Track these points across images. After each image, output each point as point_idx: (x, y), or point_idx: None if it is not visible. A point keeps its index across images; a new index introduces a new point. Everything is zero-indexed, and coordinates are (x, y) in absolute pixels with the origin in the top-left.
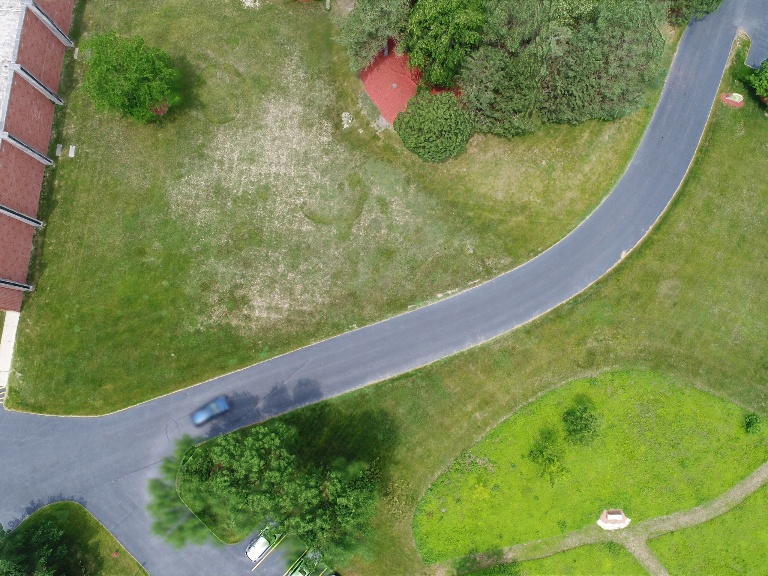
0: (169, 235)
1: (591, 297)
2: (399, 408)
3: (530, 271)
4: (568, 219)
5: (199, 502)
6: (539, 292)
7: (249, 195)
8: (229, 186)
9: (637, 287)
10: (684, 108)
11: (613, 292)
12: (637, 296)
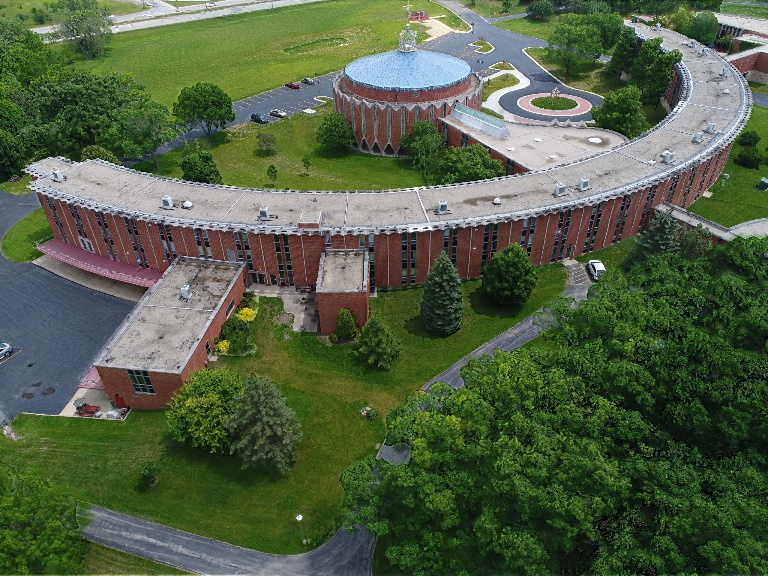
0: None
1: None
2: (738, 1)
3: None
4: None
5: None
6: None
7: None
8: None
9: None
10: None
11: None
12: None
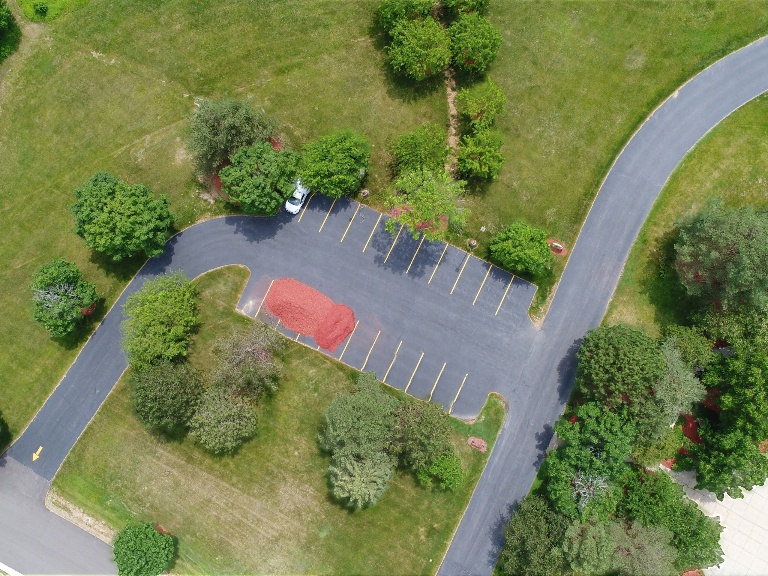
0: None
1: (710, 55)
2: None
3: (767, 81)
4: (731, 128)
5: None
6: (758, 61)
7: None
8: None
9: (666, 63)
10: (606, 240)
11: (689, 59)
12: (666, 54)
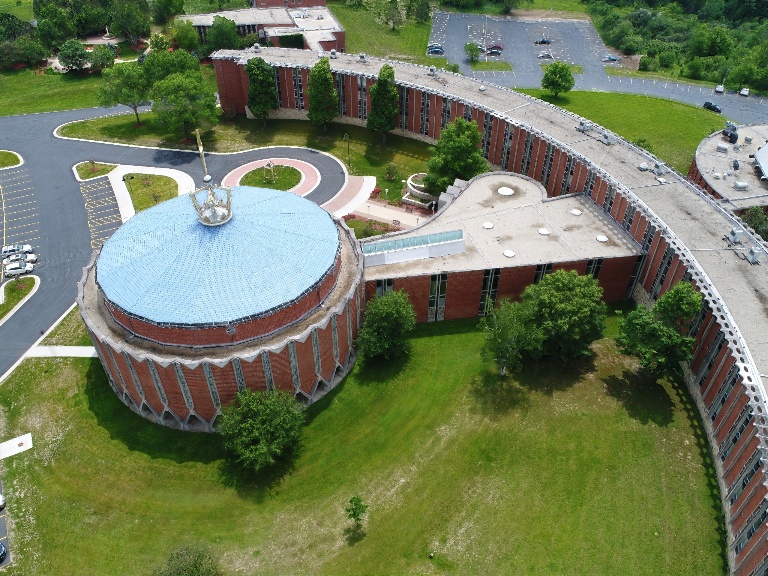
0: (208, 2)
1: None
2: None
3: None
4: None
5: None
6: None
7: (184, 8)
8: (192, 8)
9: None
10: None
11: None
12: None
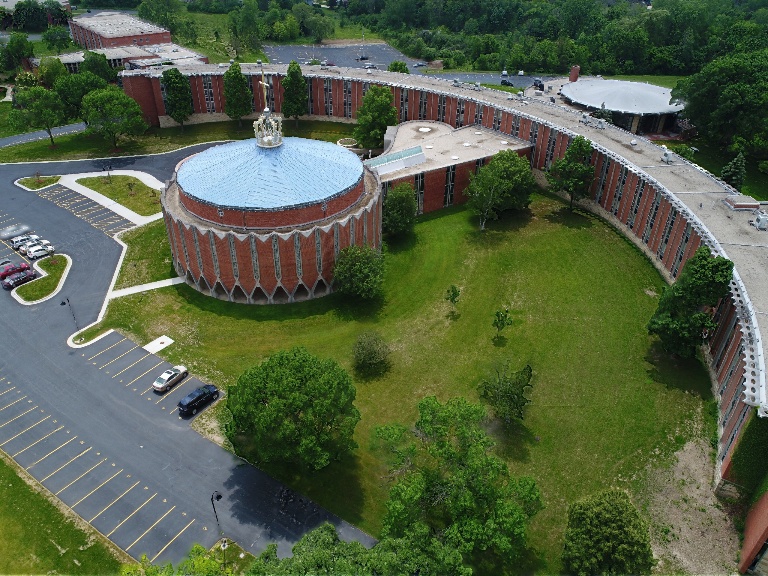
0: None
1: None
2: None
3: None
4: None
5: (0, 42)
6: None
7: None
8: None
9: None
10: None
11: None
12: None
